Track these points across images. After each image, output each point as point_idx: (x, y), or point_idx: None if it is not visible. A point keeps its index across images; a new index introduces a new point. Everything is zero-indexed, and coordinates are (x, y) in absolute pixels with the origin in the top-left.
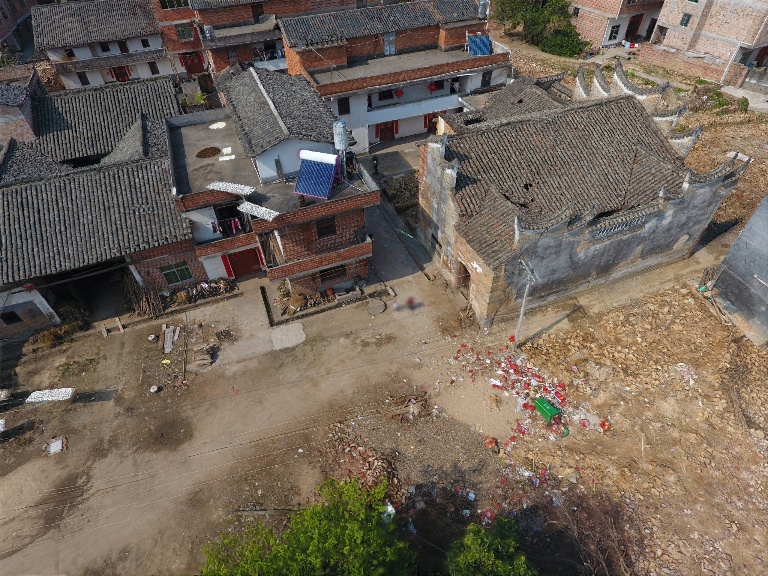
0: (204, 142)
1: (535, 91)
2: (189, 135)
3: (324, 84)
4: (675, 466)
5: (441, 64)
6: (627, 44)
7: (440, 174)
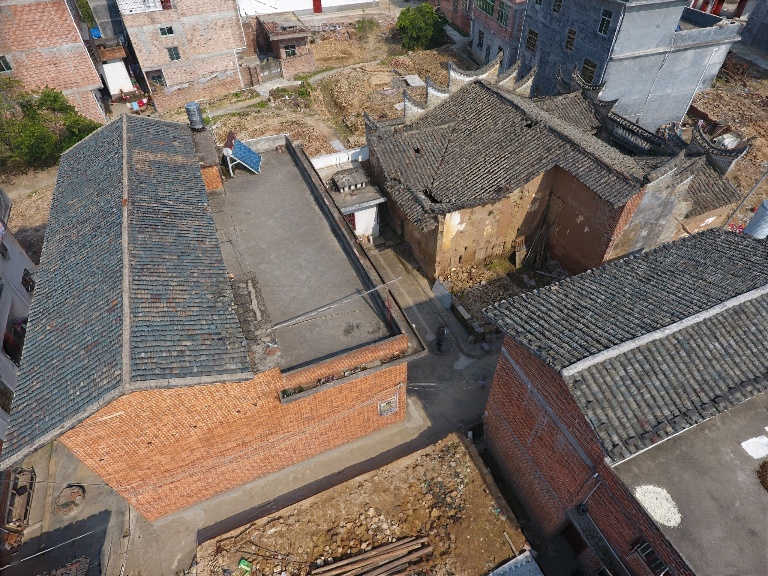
0: (753, 514)
1: (410, 134)
2: (743, 571)
3: (399, 322)
4: (767, 189)
5: (319, 188)
6: (135, 105)
7: (668, 195)
